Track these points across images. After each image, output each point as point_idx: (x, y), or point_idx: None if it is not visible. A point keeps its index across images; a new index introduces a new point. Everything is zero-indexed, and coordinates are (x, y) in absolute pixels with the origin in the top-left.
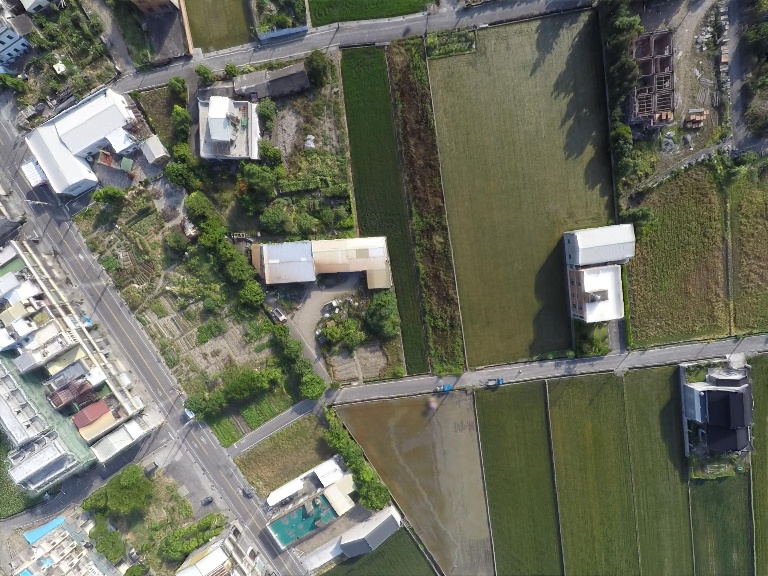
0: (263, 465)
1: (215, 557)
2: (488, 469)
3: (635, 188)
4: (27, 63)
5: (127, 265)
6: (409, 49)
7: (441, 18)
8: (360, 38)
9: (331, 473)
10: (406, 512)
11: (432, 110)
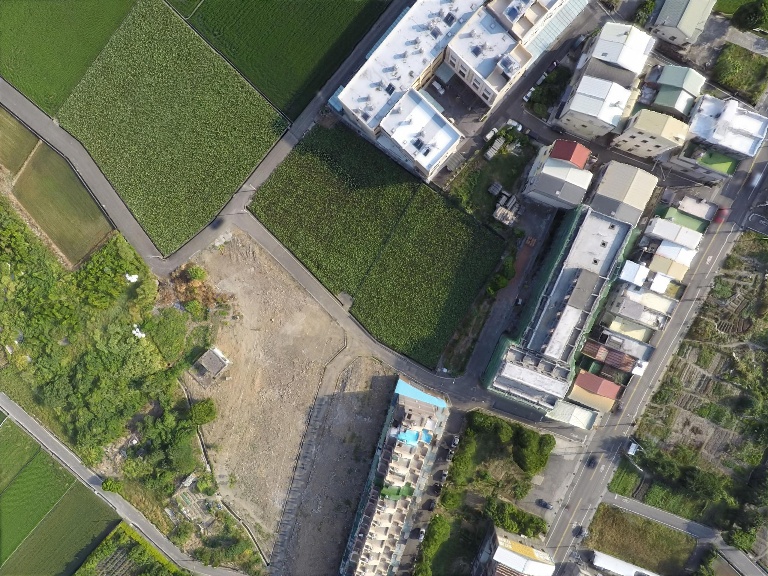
0: (615, 529)
1: (546, 570)
2: None
3: None
4: None
5: (731, 306)
6: None
7: None
8: None
9: None
10: None
11: None
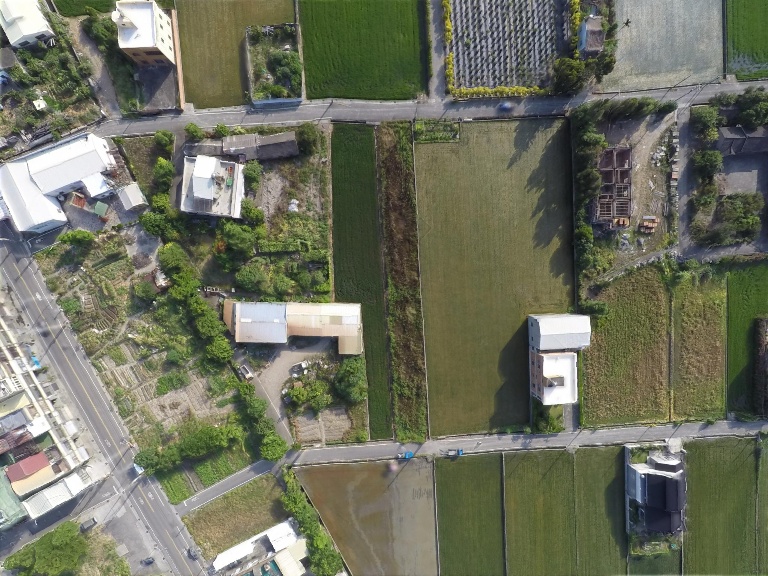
0: (213, 525)
1: None
2: (442, 538)
3: (594, 280)
4: (4, 95)
5: (88, 308)
6: (397, 131)
7: (429, 107)
8: (352, 115)
9: (284, 537)
10: None
11: (415, 190)
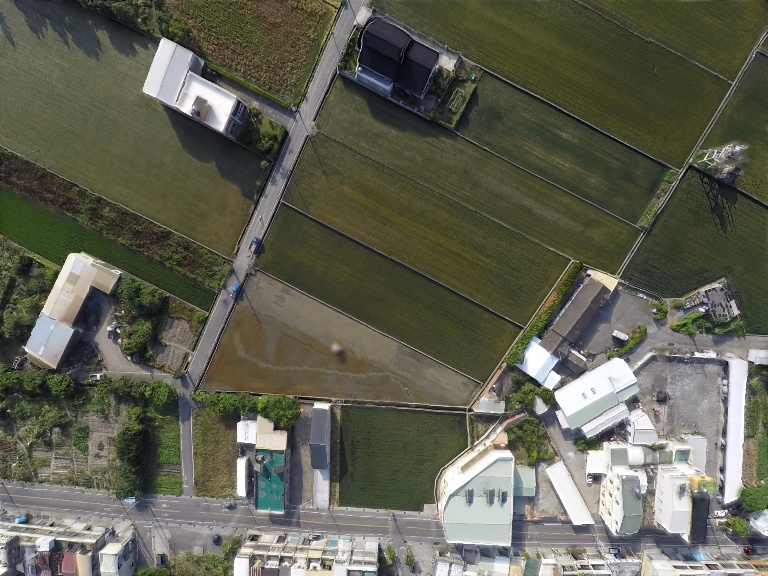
0: (215, 477)
1: (239, 567)
2: (332, 302)
3: None
4: None
5: None
6: None
7: None
8: None
9: (247, 430)
10: (328, 395)
11: None
